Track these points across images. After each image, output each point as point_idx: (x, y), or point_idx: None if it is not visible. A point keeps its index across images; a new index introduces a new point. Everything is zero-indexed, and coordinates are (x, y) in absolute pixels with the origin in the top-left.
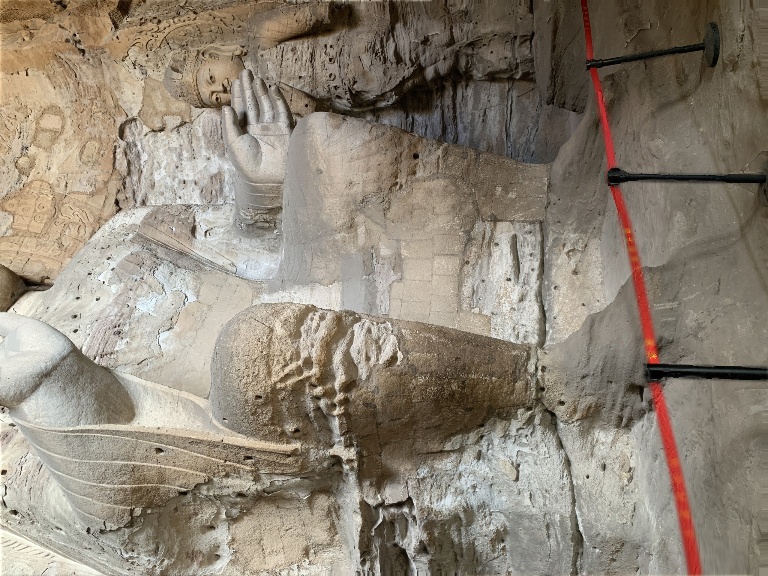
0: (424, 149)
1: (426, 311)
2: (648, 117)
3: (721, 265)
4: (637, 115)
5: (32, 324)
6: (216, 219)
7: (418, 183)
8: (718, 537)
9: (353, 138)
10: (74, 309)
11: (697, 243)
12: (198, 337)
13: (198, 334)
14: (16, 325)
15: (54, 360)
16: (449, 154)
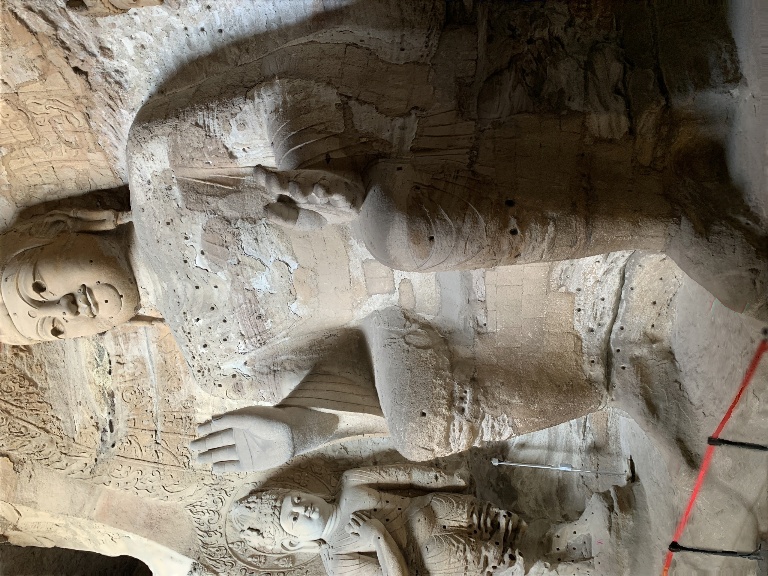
0: (527, 248)
1: (519, 296)
2: (765, 374)
3: (728, 509)
4: (763, 348)
5: (255, 427)
6: (250, 141)
7: (518, 264)
8: (667, 523)
9: (447, 263)
10: (205, 301)
11: (726, 487)
12: (321, 300)
13: (319, 298)
14: (245, 428)
15: (291, 445)
16: (555, 247)
